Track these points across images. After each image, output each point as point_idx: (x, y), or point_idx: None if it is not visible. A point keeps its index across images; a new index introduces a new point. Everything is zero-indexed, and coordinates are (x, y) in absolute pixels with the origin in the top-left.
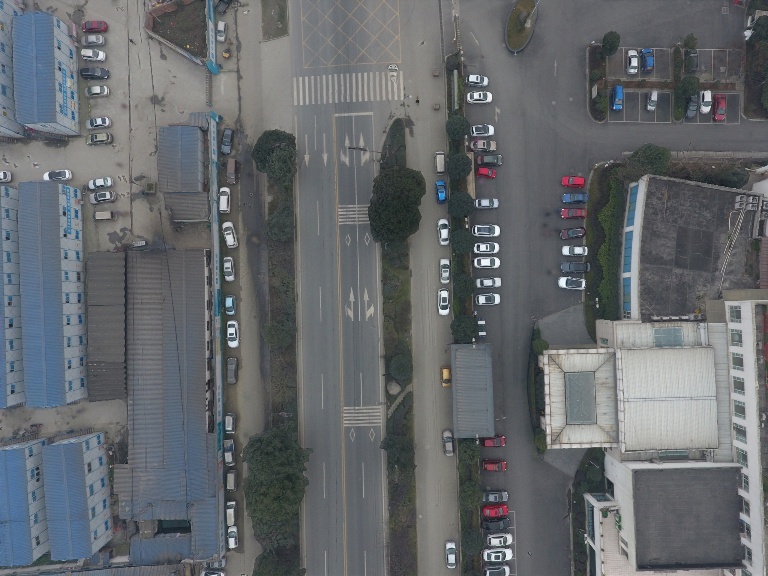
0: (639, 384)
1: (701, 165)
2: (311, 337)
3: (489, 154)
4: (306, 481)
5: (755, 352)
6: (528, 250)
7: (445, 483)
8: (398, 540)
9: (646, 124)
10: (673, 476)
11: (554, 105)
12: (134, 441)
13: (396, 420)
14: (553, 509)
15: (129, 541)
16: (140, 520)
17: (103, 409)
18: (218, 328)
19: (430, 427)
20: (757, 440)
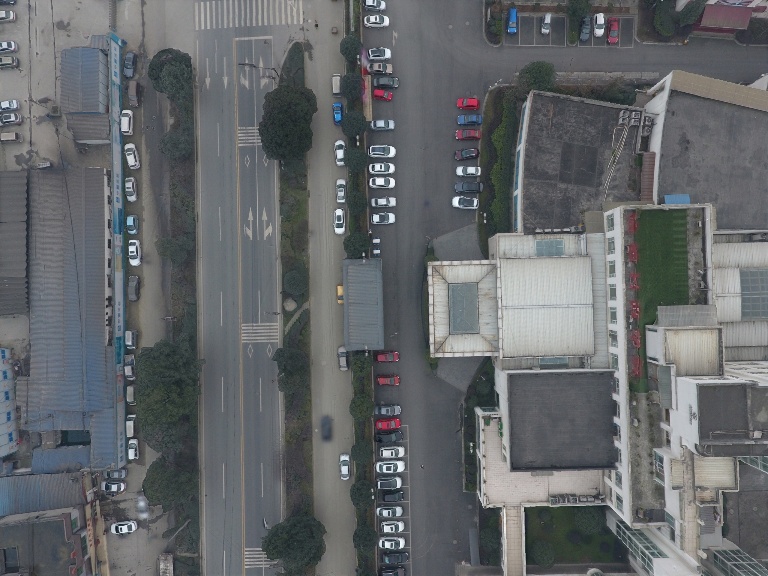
0: (517, 292)
1: (594, 87)
2: (211, 256)
3: (386, 77)
4: (197, 389)
5: (623, 255)
6: (423, 171)
7: (341, 398)
8: (293, 452)
9: (541, 48)
10: (549, 381)
11: (451, 29)
12: (36, 354)
13: (292, 336)
14: (445, 423)
15: (32, 452)
16: (42, 431)
17: (9, 326)
18: (119, 246)
19: (327, 344)
20: (624, 341)
